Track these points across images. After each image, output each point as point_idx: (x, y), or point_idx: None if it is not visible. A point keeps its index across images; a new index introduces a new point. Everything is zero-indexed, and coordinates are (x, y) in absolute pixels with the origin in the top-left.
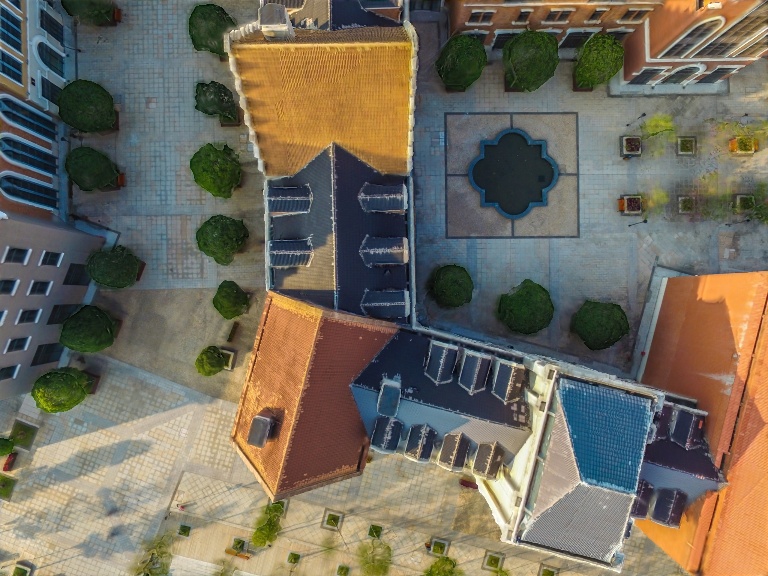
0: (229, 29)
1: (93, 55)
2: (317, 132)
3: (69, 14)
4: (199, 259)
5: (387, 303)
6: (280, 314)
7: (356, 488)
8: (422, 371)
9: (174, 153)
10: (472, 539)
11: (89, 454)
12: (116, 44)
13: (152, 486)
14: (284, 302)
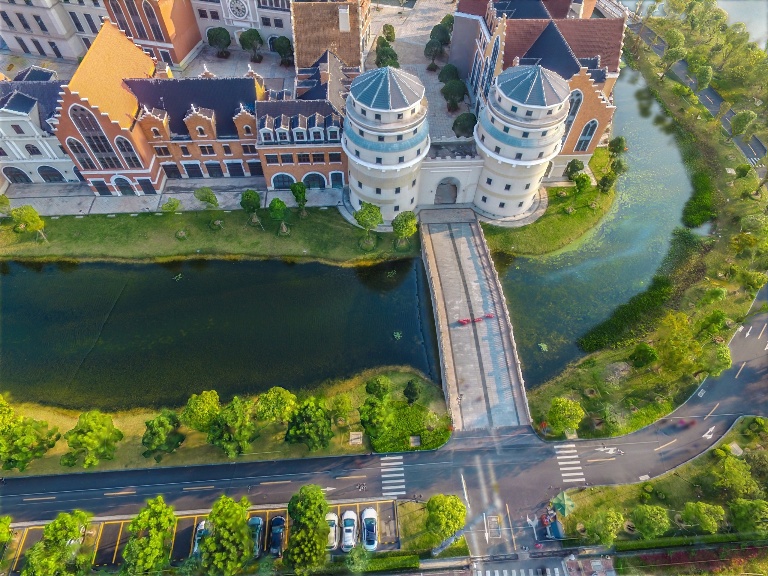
0: None
1: None
2: None
3: None
4: None
5: None
6: None
7: None
8: None
9: None
10: None
11: None
12: None
13: None
14: None
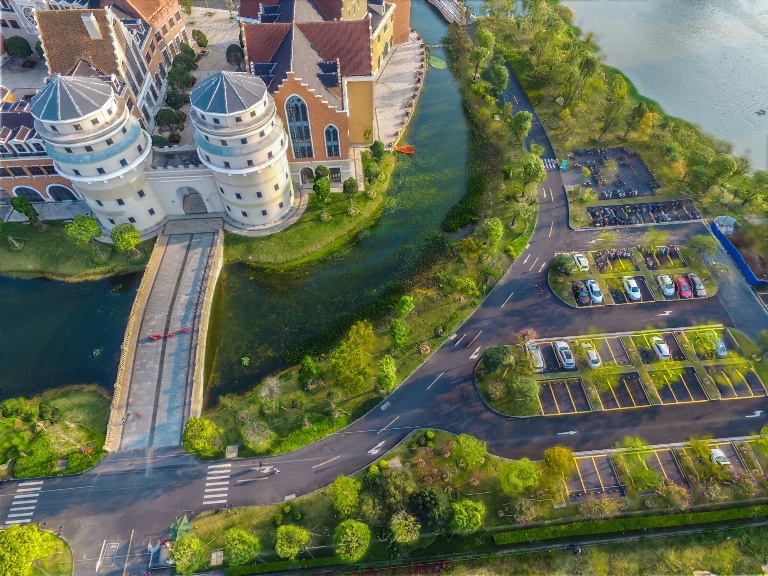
0: None
1: None
2: None
3: None
4: None
5: None
6: (139, 8)
7: None
8: (90, 1)
9: None
10: None
11: None
12: None
13: None
14: (135, 8)
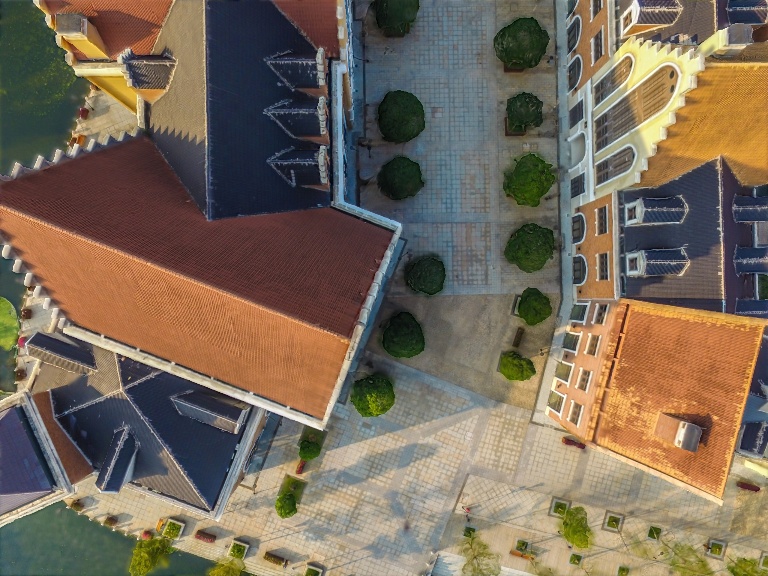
0: (545, 42)
1: (380, 65)
2: (713, 145)
3: (379, 26)
4: (483, 266)
5: (759, 311)
6: (658, 322)
7: (636, 490)
8: None
9: (459, 162)
10: (748, 540)
11: (377, 457)
12: (403, 55)
13: (438, 489)
14: (665, 310)
